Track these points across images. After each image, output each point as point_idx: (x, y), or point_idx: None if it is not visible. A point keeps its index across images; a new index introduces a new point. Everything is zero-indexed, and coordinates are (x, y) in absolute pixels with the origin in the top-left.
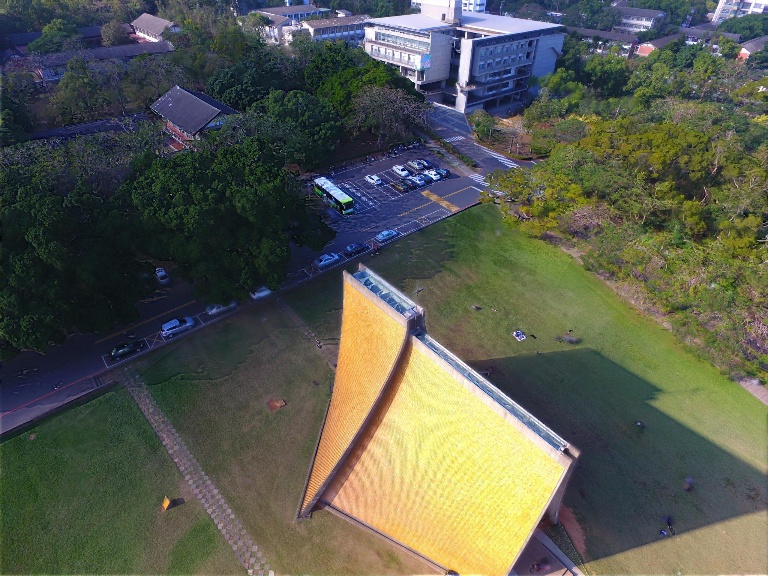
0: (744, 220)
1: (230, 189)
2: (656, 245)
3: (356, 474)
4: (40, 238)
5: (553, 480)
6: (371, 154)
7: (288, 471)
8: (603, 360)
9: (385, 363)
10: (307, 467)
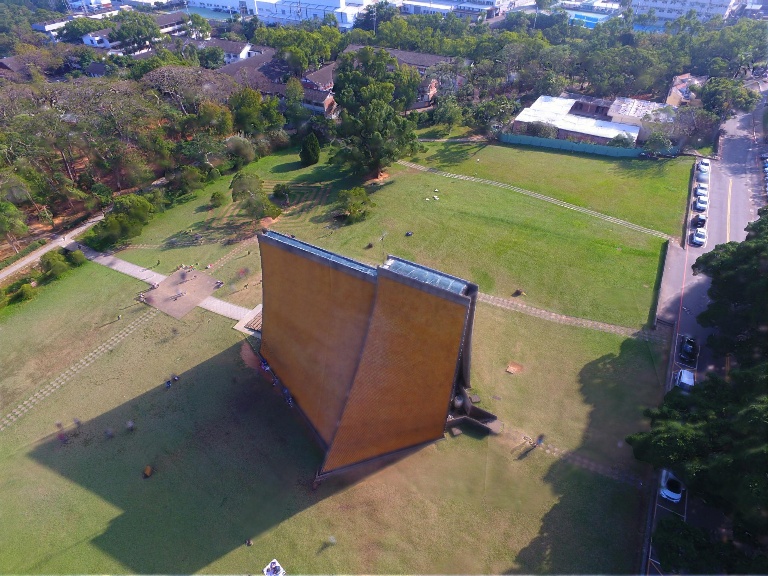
0: None
1: None
2: None
3: None
4: None
5: None
6: None
7: None
8: (151, 570)
9: None
10: None
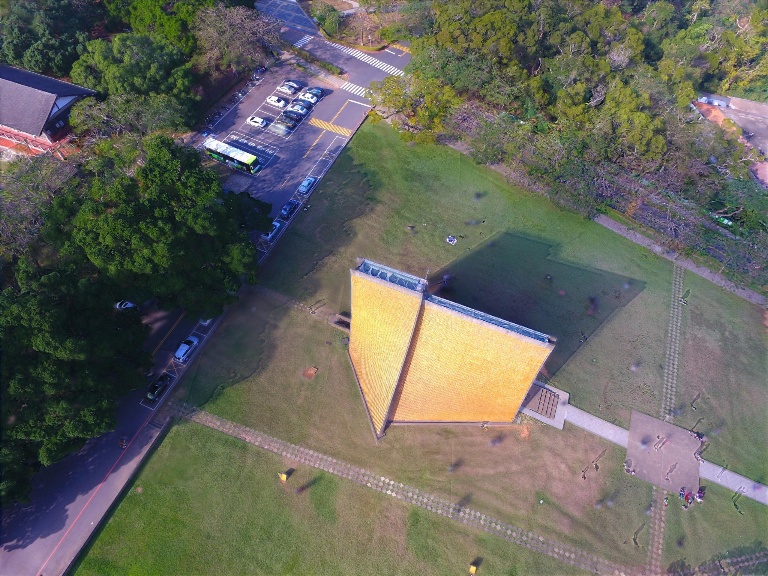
0: (574, 88)
1: (179, 213)
2: (525, 134)
3: (405, 396)
4: (53, 344)
5: (543, 357)
6: (236, 89)
7: (351, 414)
8: (512, 237)
9: (407, 323)
10: (362, 405)
